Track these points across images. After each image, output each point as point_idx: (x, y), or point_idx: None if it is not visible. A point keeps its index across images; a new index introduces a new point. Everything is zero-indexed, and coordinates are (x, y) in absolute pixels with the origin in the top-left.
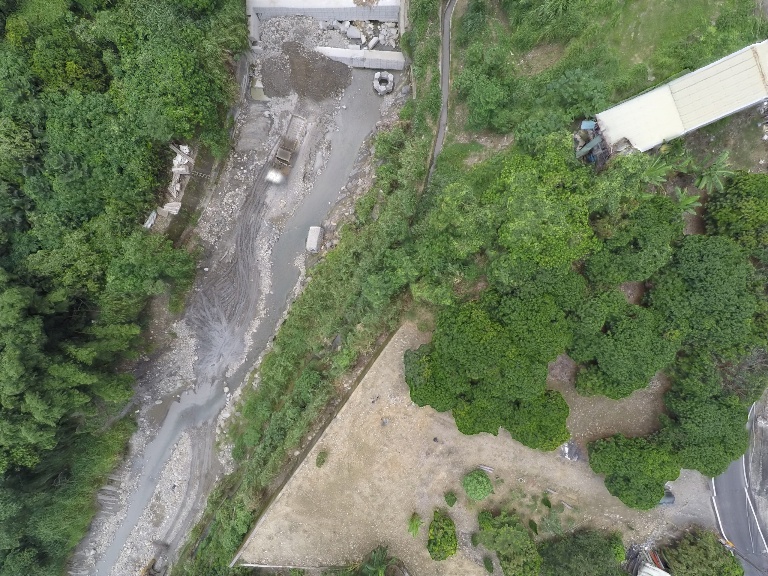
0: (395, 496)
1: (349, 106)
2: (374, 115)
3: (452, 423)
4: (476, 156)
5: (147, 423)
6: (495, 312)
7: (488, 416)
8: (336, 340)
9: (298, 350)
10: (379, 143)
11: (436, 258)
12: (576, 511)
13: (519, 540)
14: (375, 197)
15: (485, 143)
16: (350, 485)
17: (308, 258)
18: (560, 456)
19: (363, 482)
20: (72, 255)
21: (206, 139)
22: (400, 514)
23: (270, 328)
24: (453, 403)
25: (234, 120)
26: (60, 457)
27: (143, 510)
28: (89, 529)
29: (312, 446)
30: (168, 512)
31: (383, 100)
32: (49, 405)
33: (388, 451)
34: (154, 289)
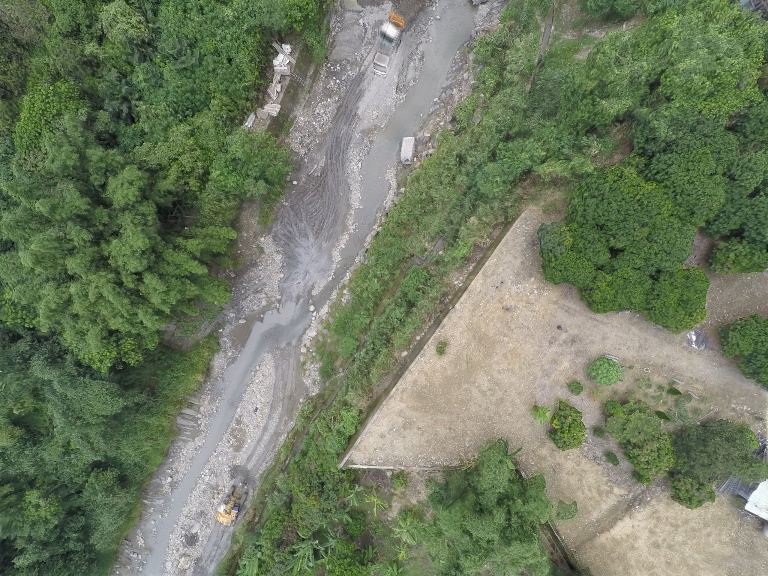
0: (514, 389)
1: (442, 17)
2: (468, 25)
3: (576, 310)
4: (590, 49)
5: (229, 343)
6: (644, 173)
7: (631, 287)
8: (436, 246)
9: (395, 259)
10: (481, 46)
11: (566, 135)
12: (705, 400)
13: (651, 426)
14: (476, 101)
15: (599, 35)
16: (468, 378)
17: (399, 171)
18: (687, 345)
19: (481, 375)
20: (177, 149)
21: (310, 37)
22: (519, 408)
23: (359, 244)
24: (593, 275)
25: (329, 27)
26: (148, 370)
27: (222, 435)
28: (166, 455)
29: (428, 338)
30: (249, 436)
31: (478, 10)
32: (167, 287)
33: (508, 342)
34: (255, 189)
